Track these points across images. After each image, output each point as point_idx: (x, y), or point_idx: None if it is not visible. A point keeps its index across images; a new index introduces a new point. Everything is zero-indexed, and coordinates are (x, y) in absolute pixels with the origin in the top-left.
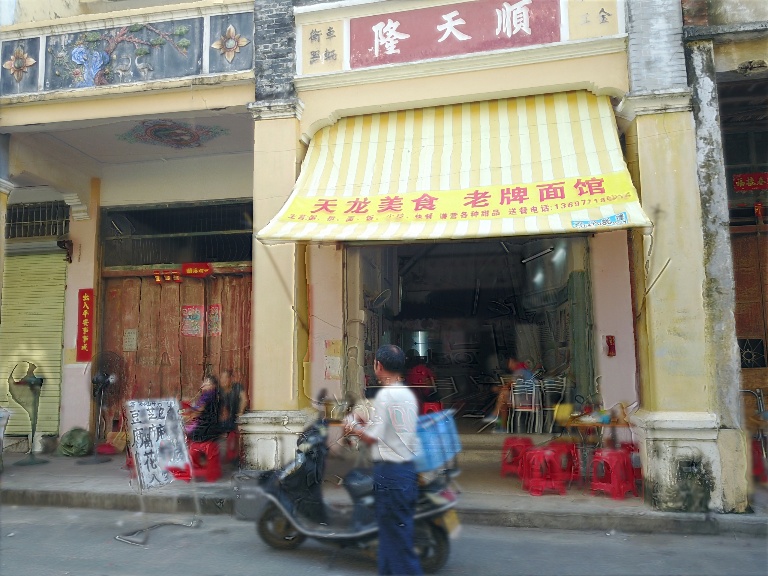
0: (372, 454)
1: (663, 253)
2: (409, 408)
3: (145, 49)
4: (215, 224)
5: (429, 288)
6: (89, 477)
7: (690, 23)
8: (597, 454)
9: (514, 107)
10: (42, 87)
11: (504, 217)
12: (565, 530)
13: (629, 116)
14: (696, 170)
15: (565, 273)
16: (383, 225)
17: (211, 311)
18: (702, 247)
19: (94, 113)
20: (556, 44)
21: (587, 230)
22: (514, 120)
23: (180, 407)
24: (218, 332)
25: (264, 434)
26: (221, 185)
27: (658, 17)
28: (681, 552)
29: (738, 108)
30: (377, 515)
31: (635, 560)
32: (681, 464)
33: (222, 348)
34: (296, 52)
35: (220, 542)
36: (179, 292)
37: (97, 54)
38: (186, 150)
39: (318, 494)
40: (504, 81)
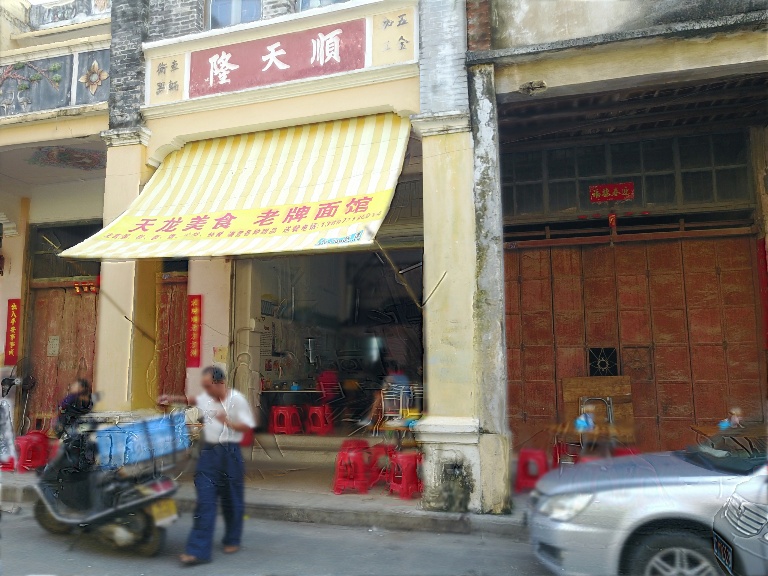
0: (244, 454)
1: (440, 266)
2: (294, 412)
3: (25, 84)
4: None
5: (315, 298)
6: None
7: (474, 48)
8: (393, 456)
9: (330, 130)
10: None
11: (276, 235)
12: (337, 526)
13: (421, 137)
14: (472, 187)
15: None
16: (174, 243)
17: None
18: (475, 260)
19: None
20: (357, 71)
21: (320, 247)
22: (327, 142)
23: (63, 407)
24: None
25: (100, 432)
26: None
27: (445, 43)
28: (410, 547)
29: (576, 122)
30: (182, 508)
31: (352, 552)
32: (446, 466)
33: None
34: (145, 84)
35: (19, 526)
36: (95, 302)
37: None
38: (96, 171)
39: (147, 488)
40: (317, 106)
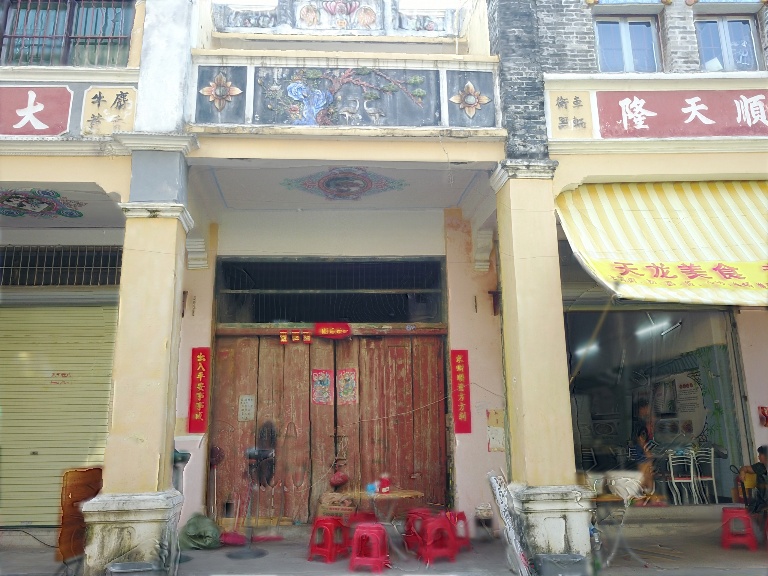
0: None
1: None
2: None
3: (376, 94)
4: (352, 282)
5: (573, 357)
6: (299, 573)
7: None
8: None
9: (750, 189)
10: (251, 119)
11: None
12: None
13: None
14: None
15: (677, 347)
16: (719, 291)
17: (345, 376)
18: None
19: (317, 153)
20: None
21: None
22: (757, 201)
23: (383, 485)
24: (355, 400)
25: (554, 512)
26: (362, 241)
27: None
28: None
29: None
30: None
31: None
32: None
33: (361, 418)
34: None
35: None
36: (309, 354)
37: (319, 92)
38: (335, 202)
39: None
40: (748, 165)
